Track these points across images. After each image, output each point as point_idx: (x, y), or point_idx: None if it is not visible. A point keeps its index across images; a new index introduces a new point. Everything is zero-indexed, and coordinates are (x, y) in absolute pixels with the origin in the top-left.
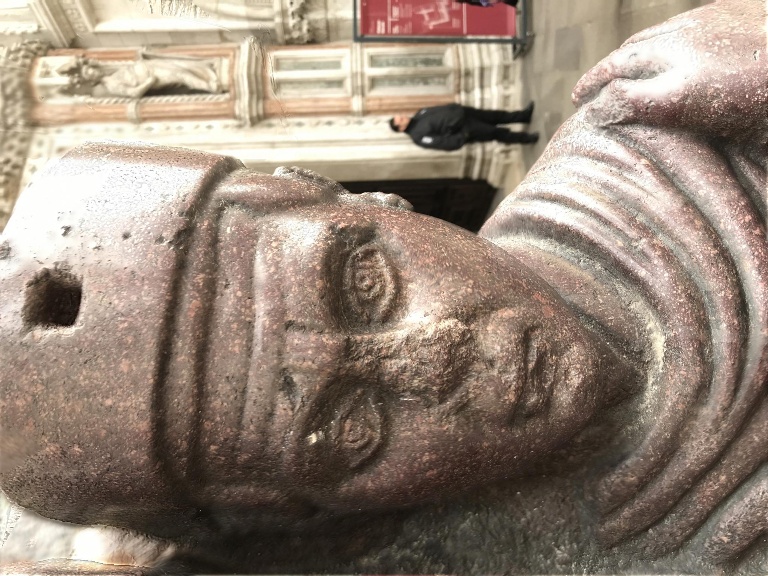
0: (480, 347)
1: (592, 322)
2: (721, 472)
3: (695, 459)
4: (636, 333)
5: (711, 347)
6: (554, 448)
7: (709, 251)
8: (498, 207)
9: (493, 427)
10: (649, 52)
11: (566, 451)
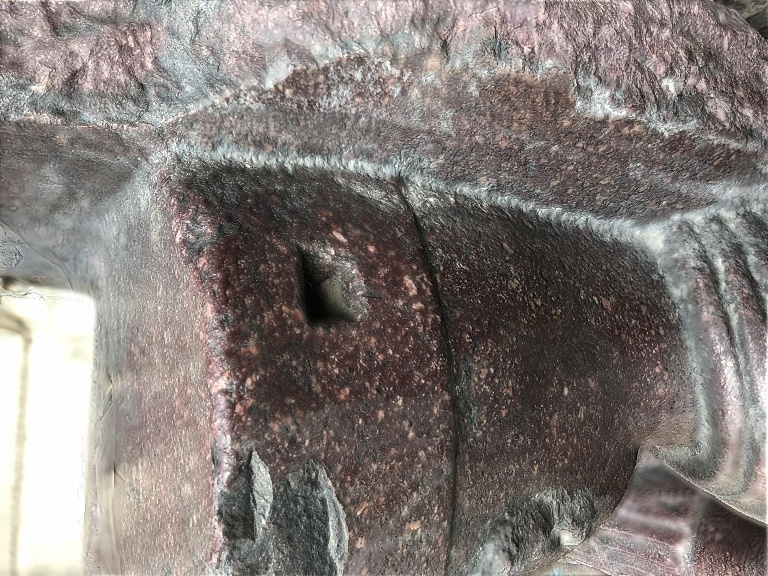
0: None
1: None
2: None
3: None
4: None
5: None
6: None
7: None
8: (754, 398)
9: None
10: None
11: None
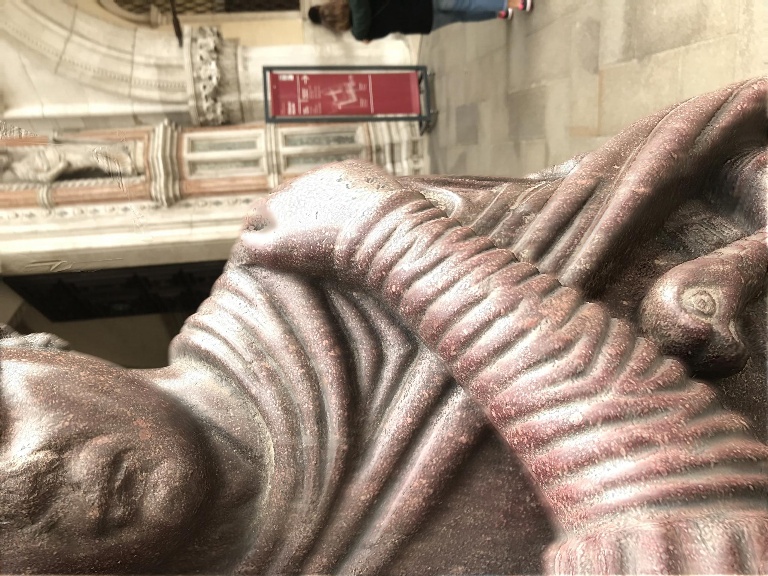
0: (69, 472)
1: (223, 433)
2: (323, 555)
3: (298, 546)
4: (258, 440)
5: (302, 450)
6: (161, 550)
7: (297, 370)
8: None
9: (87, 539)
10: (260, 208)
11: (208, 548)
